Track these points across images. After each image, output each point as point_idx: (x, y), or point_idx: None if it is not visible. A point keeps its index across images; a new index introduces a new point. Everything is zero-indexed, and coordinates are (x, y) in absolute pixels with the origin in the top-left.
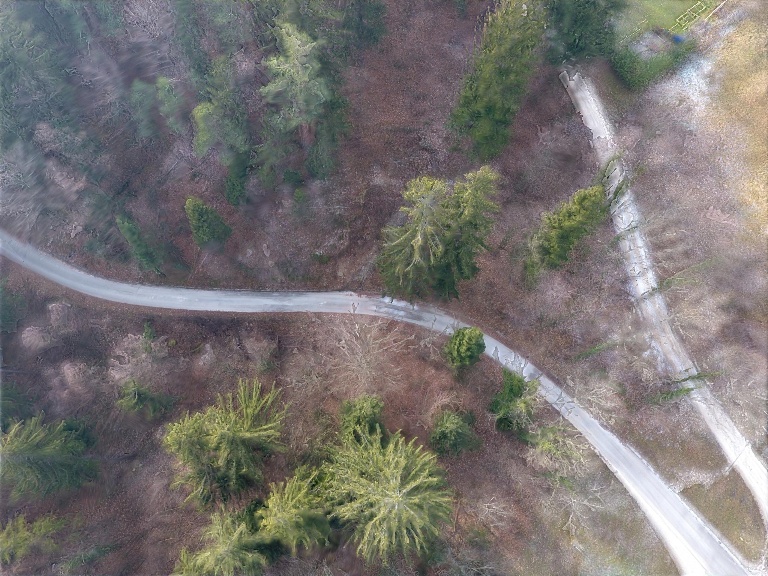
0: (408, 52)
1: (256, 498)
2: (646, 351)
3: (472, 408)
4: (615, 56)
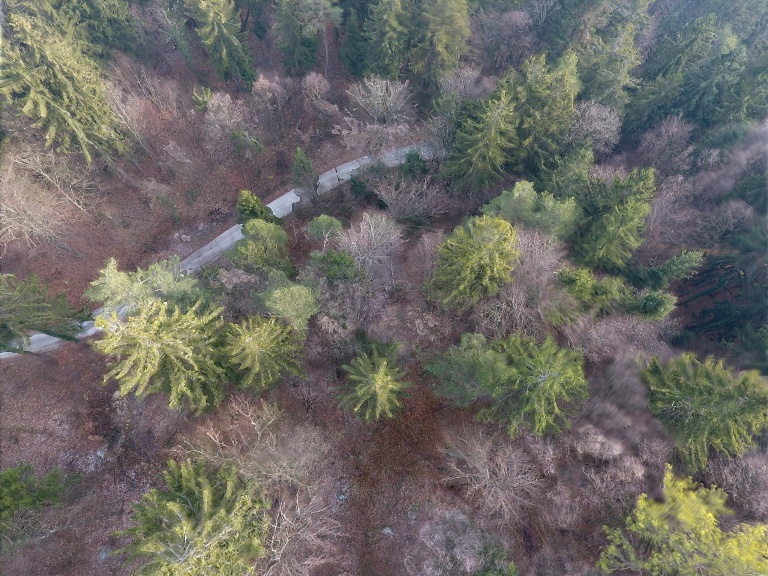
0: None
1: None
2: None
3: None
4: None
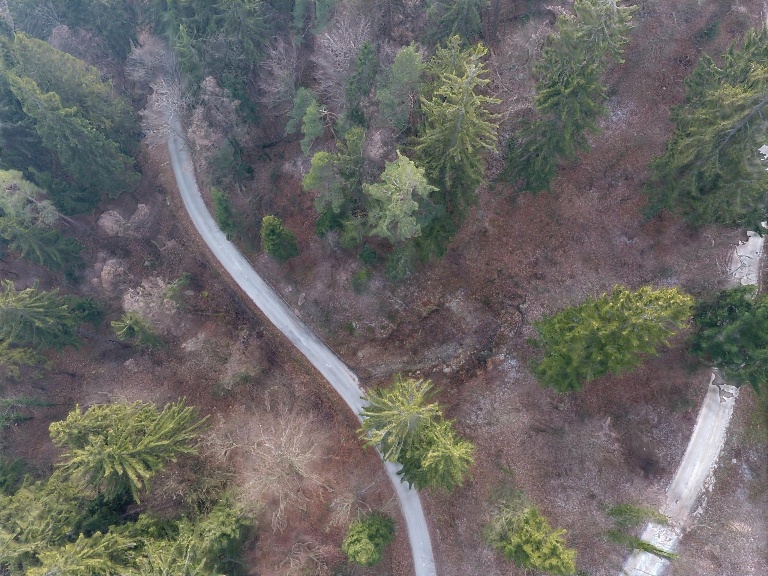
0: (580, 218)
1: (118, 493)
2: None
3: (359, 570)
4: None
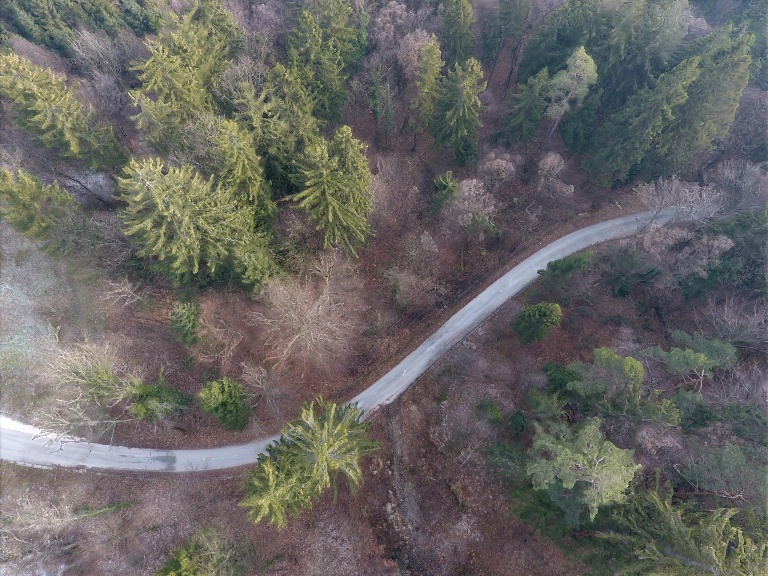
0: None
1: None
2: (62, 574)
3: None
4: None
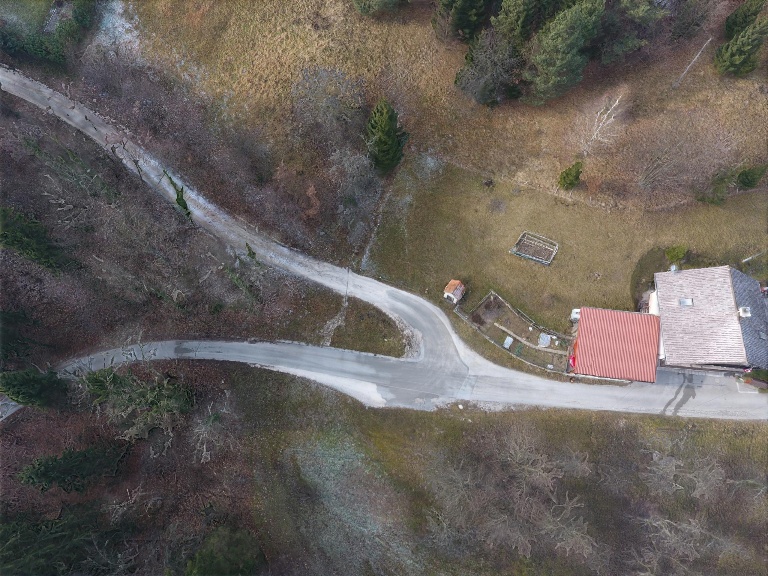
0: None
1: None
2: (236, 262)
3: None
4: (33, 47)
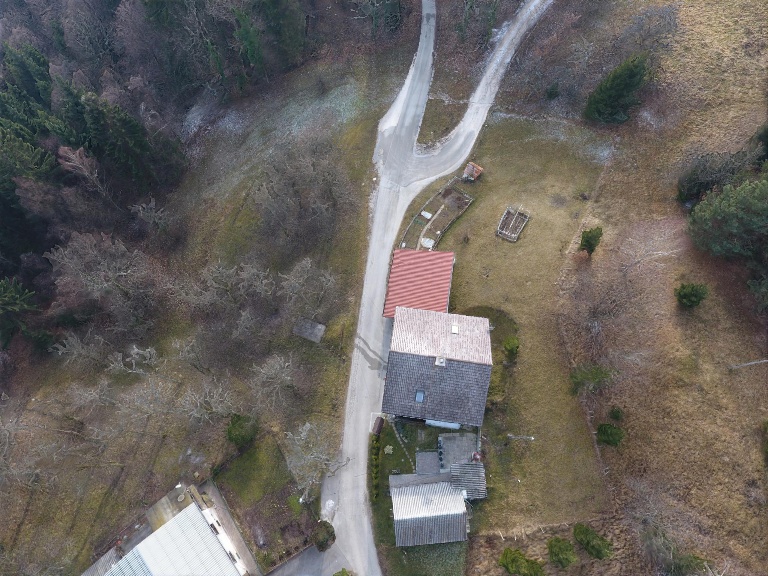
0: None
1: None
2: (496, 29)
3: None
4: None
